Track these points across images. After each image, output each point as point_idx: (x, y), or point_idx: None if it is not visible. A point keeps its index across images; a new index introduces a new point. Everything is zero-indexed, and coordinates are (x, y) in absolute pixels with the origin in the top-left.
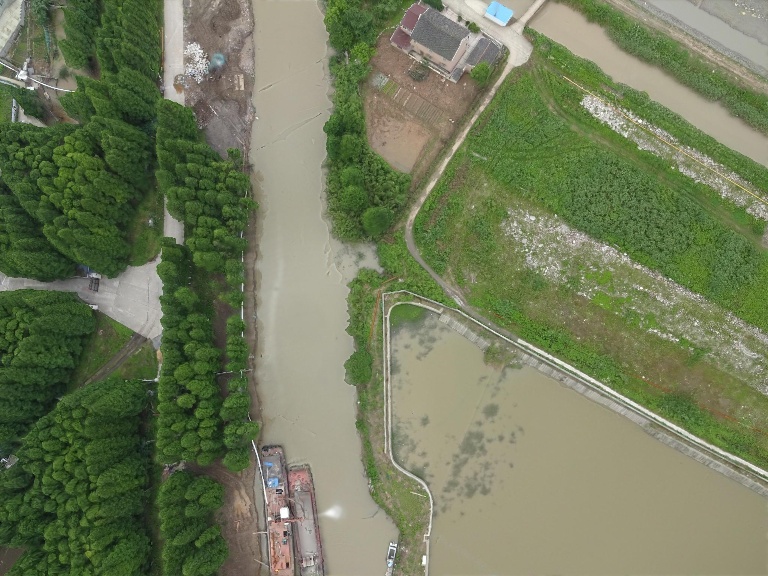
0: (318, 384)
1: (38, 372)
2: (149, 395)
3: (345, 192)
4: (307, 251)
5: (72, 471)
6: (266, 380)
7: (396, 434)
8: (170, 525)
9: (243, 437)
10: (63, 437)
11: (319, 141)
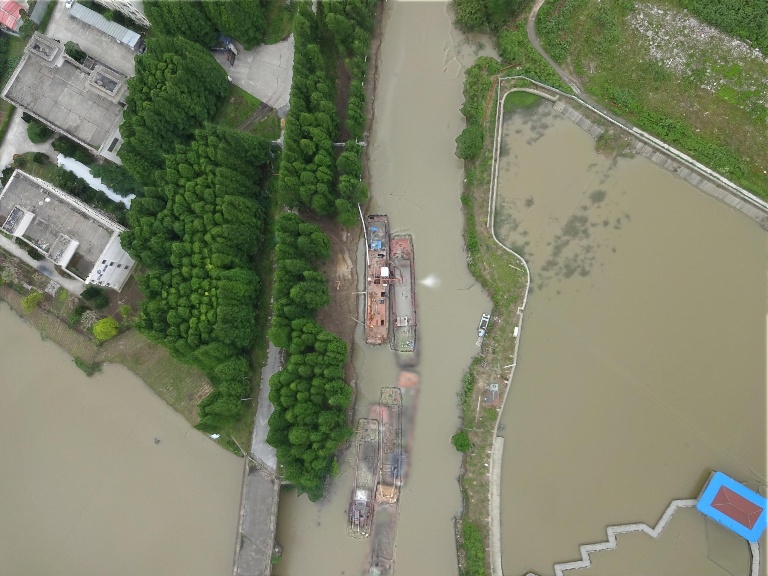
0: (426, 166)
1: (179, 112)
2: (271, 155)
3: None
4: (426, 51)
5: (201, 194)
6: (376, 164)
7: (499, 213)
8: (283, 249)
9: (355, 189)
10: (196, 165)
11: None
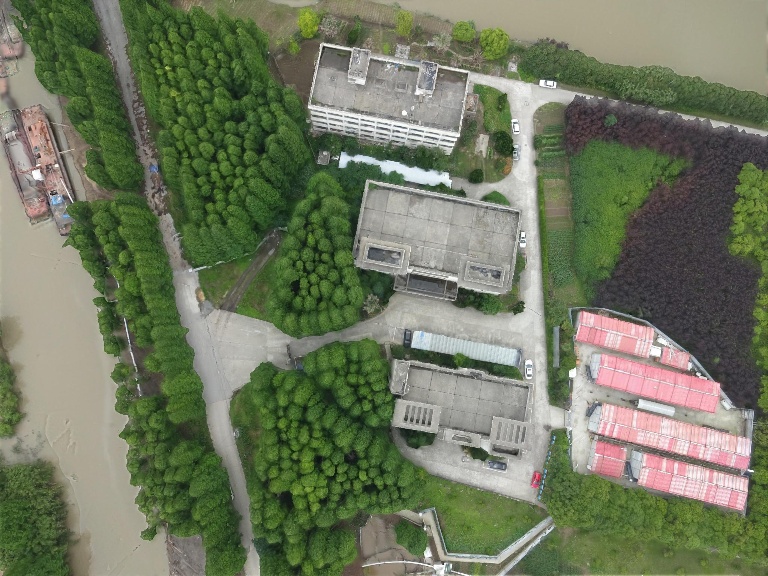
0: (46, 305)
1: None
2: None
3: (3, 519)
4: (100, 440)
5: None
6: None
7: None
8: None
9: None
10: None
11: (102, 570)
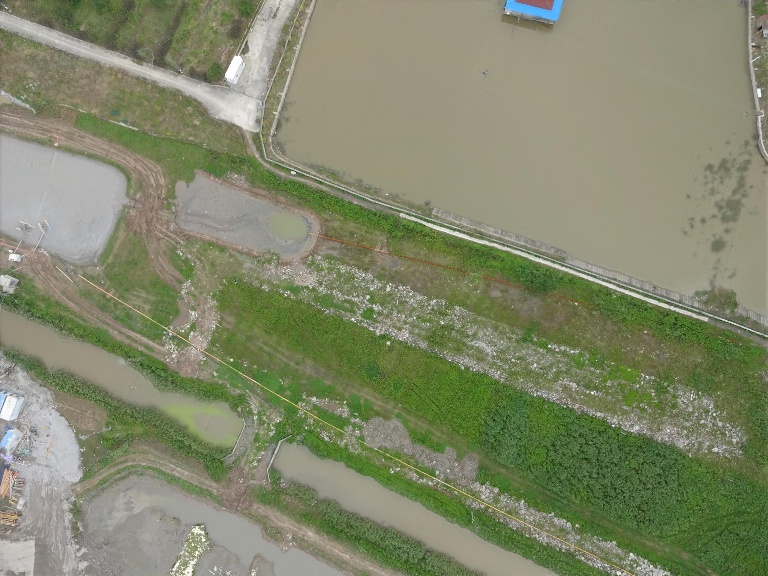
0: None
1: None
2: None
3: None
4: None
5: None
6: None
7: None
8: None
9: None
10: None
11: None
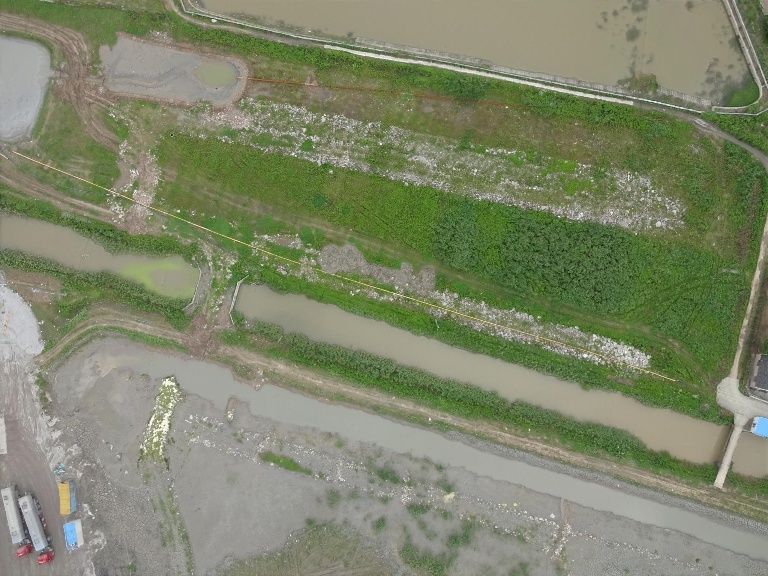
0: None
1: None
2: None
3: None
4: None
5: None
6: None
7: None
8: None
9: None
10: None
11: None
